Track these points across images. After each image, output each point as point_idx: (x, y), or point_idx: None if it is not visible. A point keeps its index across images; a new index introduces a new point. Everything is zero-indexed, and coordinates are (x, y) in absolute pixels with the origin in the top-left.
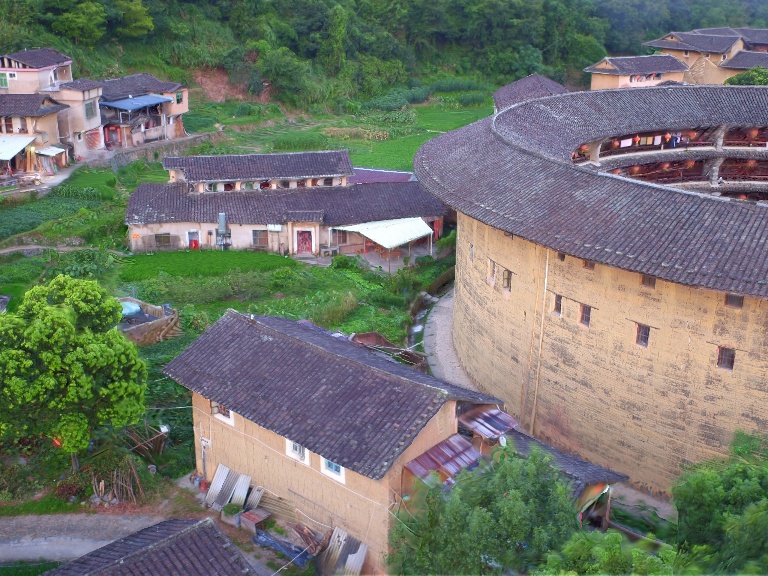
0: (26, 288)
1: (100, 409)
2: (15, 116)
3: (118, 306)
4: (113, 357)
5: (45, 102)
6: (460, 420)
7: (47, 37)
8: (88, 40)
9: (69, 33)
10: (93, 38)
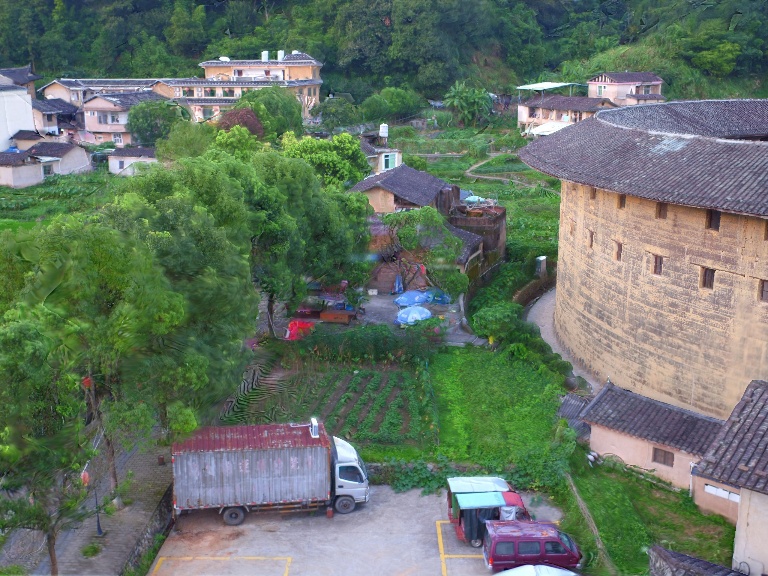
0: (476, 194)
1: (324, 187)
2: (583, 112)
3: (353, 147)
4: (325, 161)
5: (605, 104)
6: (397, 206)
7: (682, 68)
8: (719, 72)
9: (703, 66)
10: (723, 71)
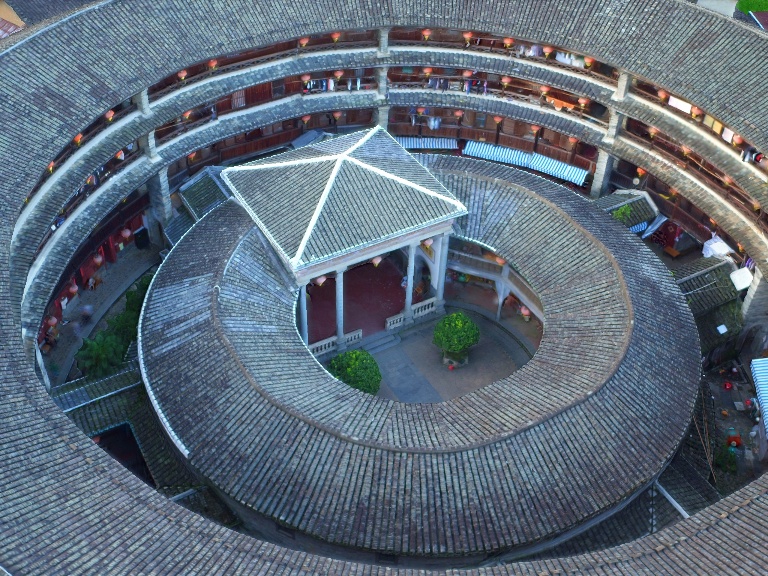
0: None
1: None
2: None
3: None
4: None
5: None
6: None
7: None
8: None
9: None
10: None
